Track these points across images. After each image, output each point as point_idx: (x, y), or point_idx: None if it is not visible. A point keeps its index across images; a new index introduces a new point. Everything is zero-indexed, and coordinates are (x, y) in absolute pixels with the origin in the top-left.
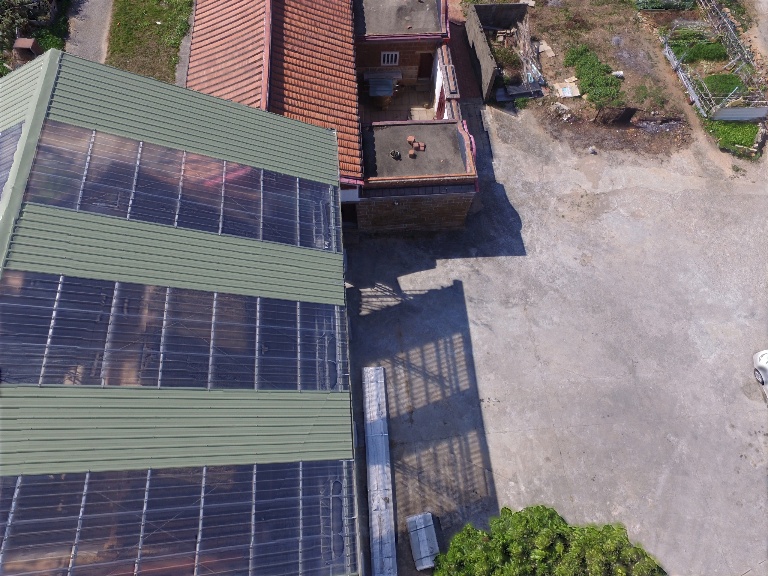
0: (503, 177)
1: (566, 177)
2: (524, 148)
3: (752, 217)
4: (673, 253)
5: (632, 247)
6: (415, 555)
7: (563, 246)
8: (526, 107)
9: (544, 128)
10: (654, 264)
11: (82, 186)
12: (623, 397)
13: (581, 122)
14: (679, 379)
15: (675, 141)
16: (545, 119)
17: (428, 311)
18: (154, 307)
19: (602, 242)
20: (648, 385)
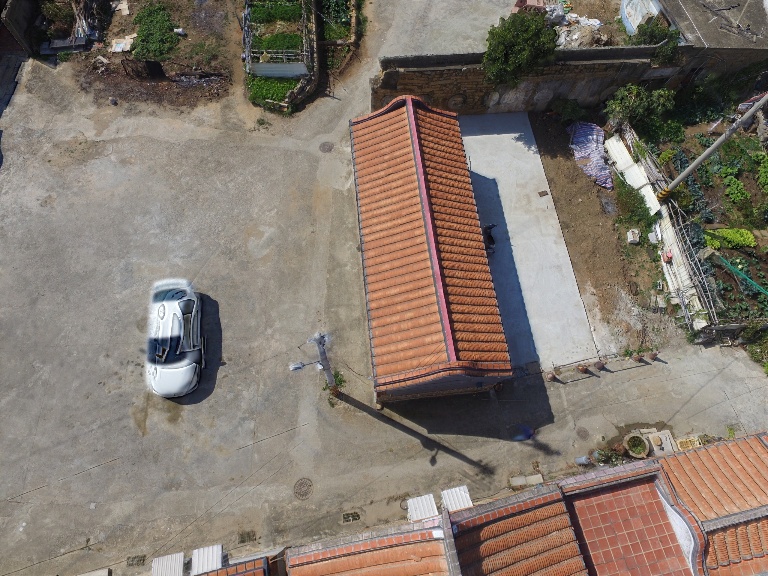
0: (7, 124)
1: (73, 125)
2: (45, 98)
3: (248, 167)
4: (142, 197)
5: (103, 191)
6: None
7: (32, 188)
8: (68, 60)
9: (76, 80)
10: (116, 207)
11: None
12: (9, 326)
13: (114, 75)
14: (77, 311)
15: (207, 95)
16: (82, 72)
17: None
18: None
19: (75, 185)
20: (42, 316)
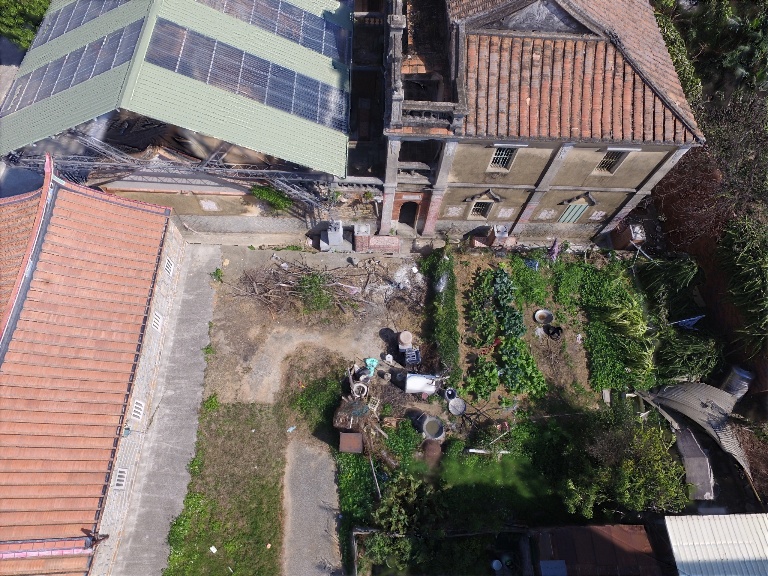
0: None
1: None
2: None
3: None
4: None
5: None
6: None
7: None
8: None
9: None
10: None
11: (122, 37)
12: None
13: None
14: None
15: None
16: None
17: (30, 185)
18: (107, 6)
19: None
20: None
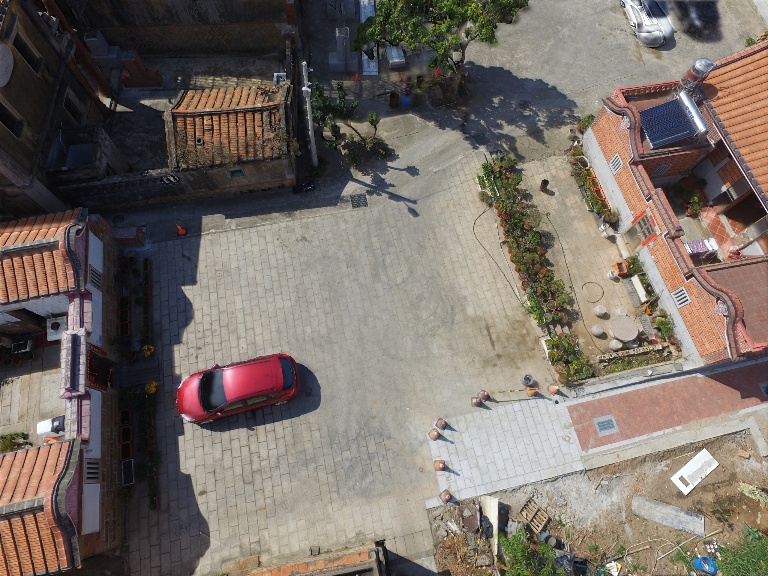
0: None
1: None
2: None
3: None
4: None
5: None
6: (389, 56)
7: None
8: None
9: None
10: None
11: None
12: (530, 7)
13: None
14: (568, 1)
15: None
16: None
17: None
18: None
19: None
20: (547, 3)
